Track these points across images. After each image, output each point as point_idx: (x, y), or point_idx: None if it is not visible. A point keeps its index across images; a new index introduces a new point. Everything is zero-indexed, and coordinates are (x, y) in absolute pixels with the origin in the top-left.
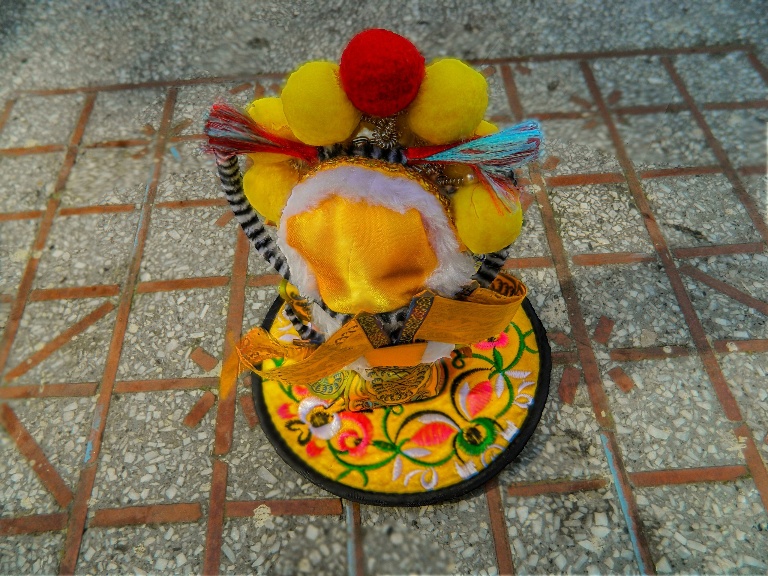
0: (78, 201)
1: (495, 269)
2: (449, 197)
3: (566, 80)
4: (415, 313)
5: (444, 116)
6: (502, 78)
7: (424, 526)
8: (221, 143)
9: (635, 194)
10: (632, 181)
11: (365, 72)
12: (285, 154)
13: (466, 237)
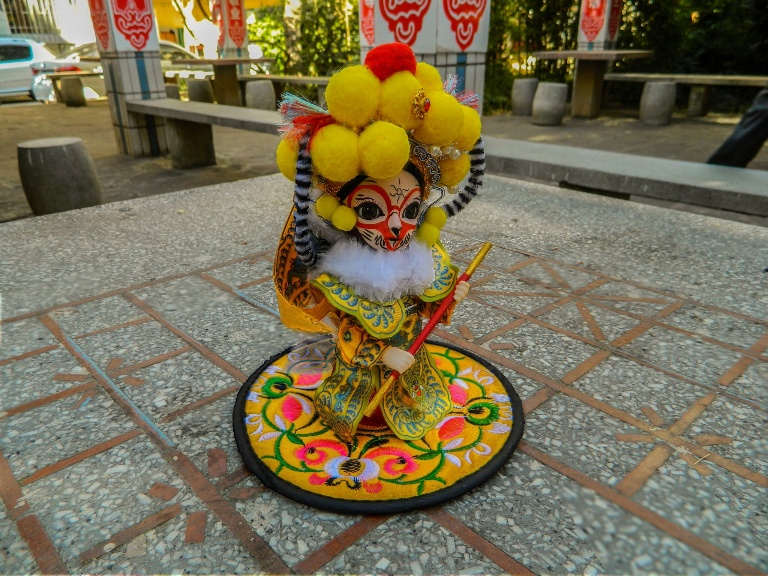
0: (760, 368)
1: None
2: None
3: None
4: None
5: None
6: None
7: None
8: None
9: None
10: None
11: None
12: None
13: None
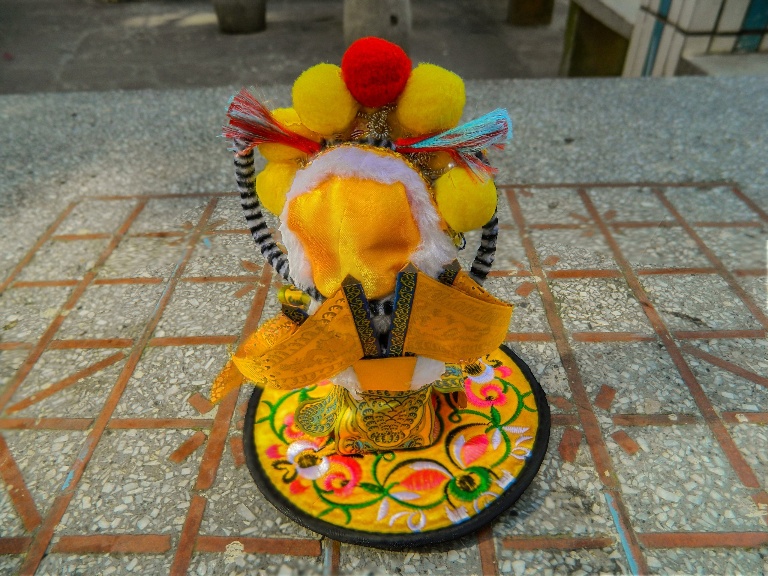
0: (113, 274)
1: (481, 277)
2: (432, 181)
3: (565, 202)
4: (401, 300)
5: (426, 102)
6: (507, 198)
7: (408, 574)
8: (240, 126)
9: (633, 287)
10: (629, 277)
11: (361, 60)
12: (293, 148)
13: (445, 208)
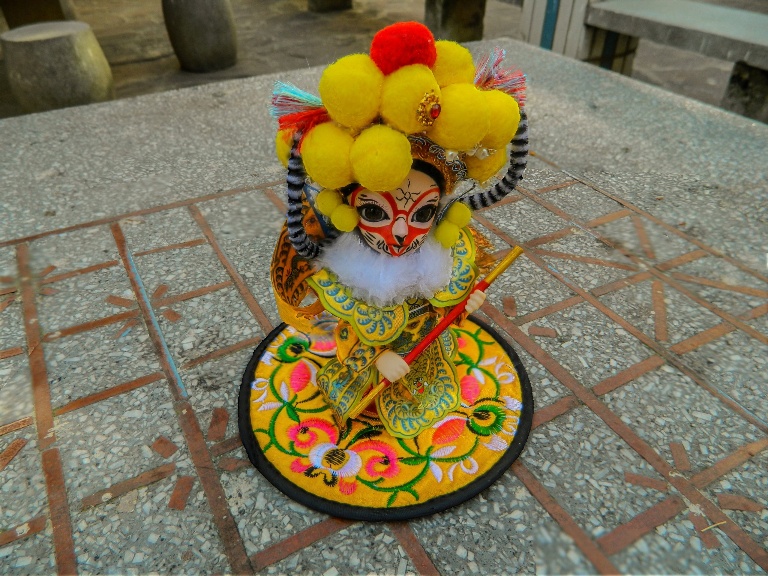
0: None
1: None
2: None
3: None
4: None
5: None
6: None
7: None
8: None
9: None
10: None
11: None
12: None
13: None
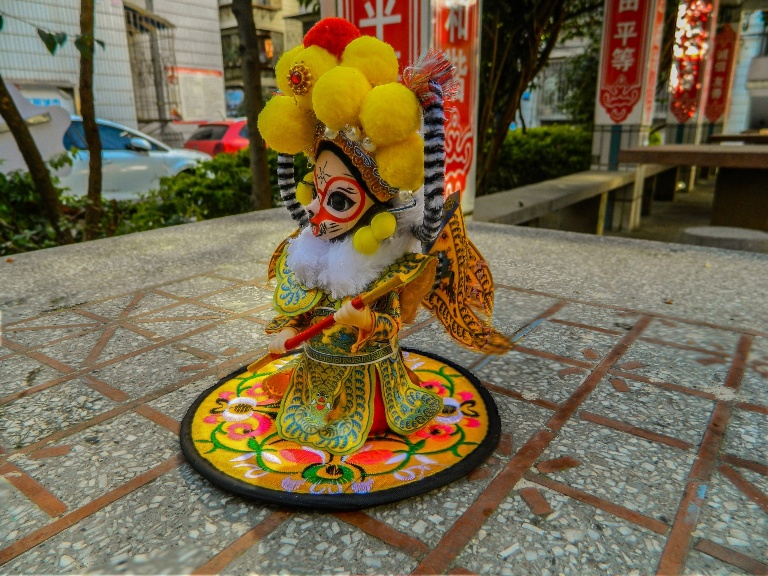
0: None
1: None
2: None
3: None
4: None
5: None
6: None
7: None
8: None
9: None
10: None
11: None
12: None
13: None
